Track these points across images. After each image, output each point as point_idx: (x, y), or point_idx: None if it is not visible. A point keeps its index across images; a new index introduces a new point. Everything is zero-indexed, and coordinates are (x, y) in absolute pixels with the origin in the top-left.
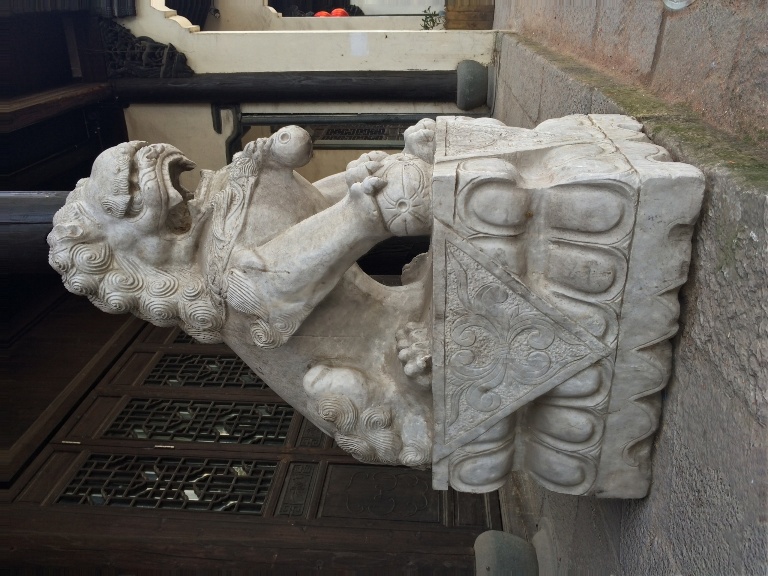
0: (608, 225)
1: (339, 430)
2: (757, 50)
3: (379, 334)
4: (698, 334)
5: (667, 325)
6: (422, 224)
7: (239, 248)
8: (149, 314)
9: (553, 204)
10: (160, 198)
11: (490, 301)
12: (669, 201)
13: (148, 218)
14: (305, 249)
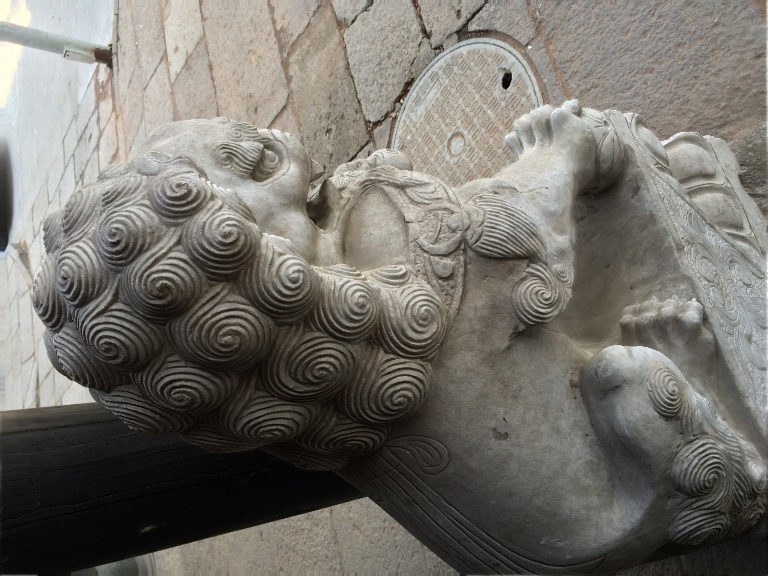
0: (713, 169)
1: (689, 429)
2: None
3: None
4: None
5: None
6: (620, 151)
7: None
8: (341, 311)
9: (669, 161)
10: (306, 153)
11: (699, 230)
12: (726, 155)
13: (295, 175)
14: (542, 171)
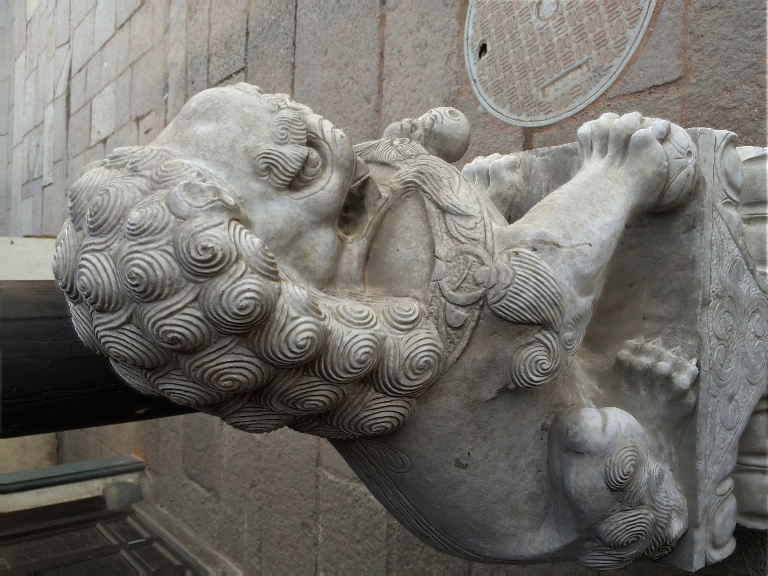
0: None
1: (629, 501)
2: (718, 109)
3: (574, 376)
4: None
5: None
6: None
7: (498, 225)
8: (341, 365)
9: (745, 179)
10: (353, 157)
11: (736, 279)
12: None
13: (334, 189)
14: (595, 215)
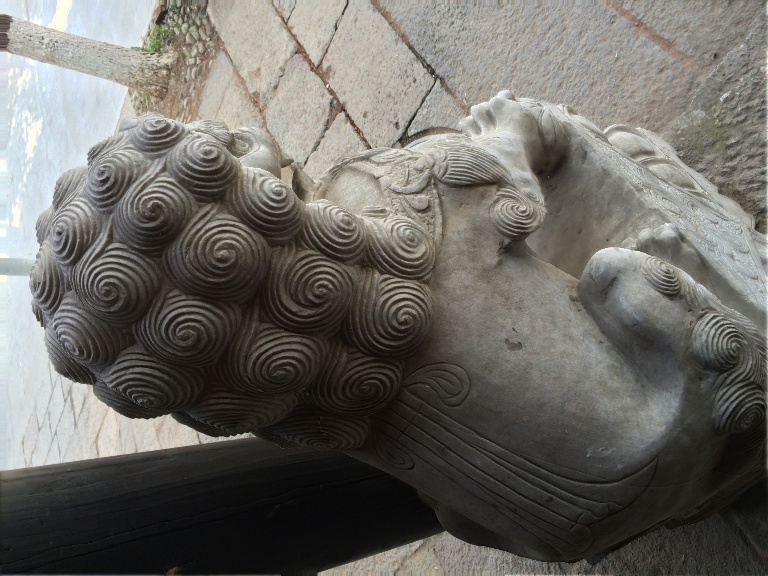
0: None
1: (695, 304)
2: None
3: None
4: (765, 195)
5: (744, 211)
6: None
7: None
8: (329, 227)
9: None
10: None
11: None
12: None
13: (266, 152)
14: None
